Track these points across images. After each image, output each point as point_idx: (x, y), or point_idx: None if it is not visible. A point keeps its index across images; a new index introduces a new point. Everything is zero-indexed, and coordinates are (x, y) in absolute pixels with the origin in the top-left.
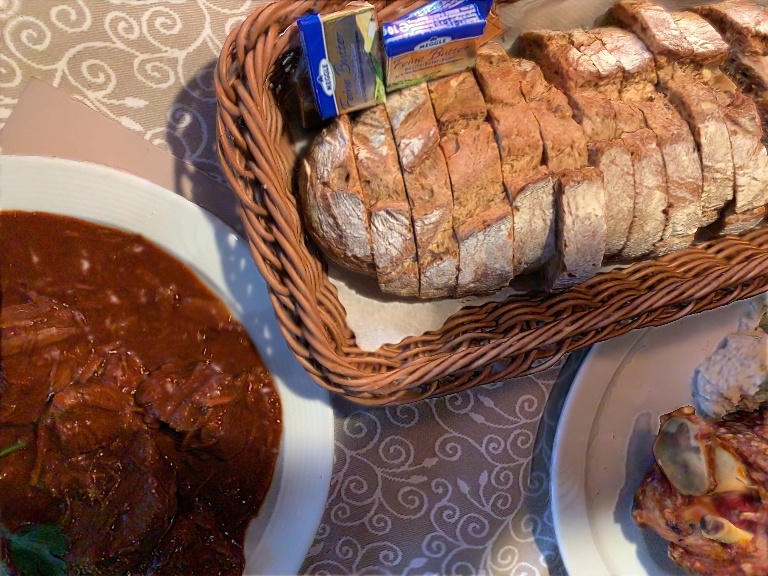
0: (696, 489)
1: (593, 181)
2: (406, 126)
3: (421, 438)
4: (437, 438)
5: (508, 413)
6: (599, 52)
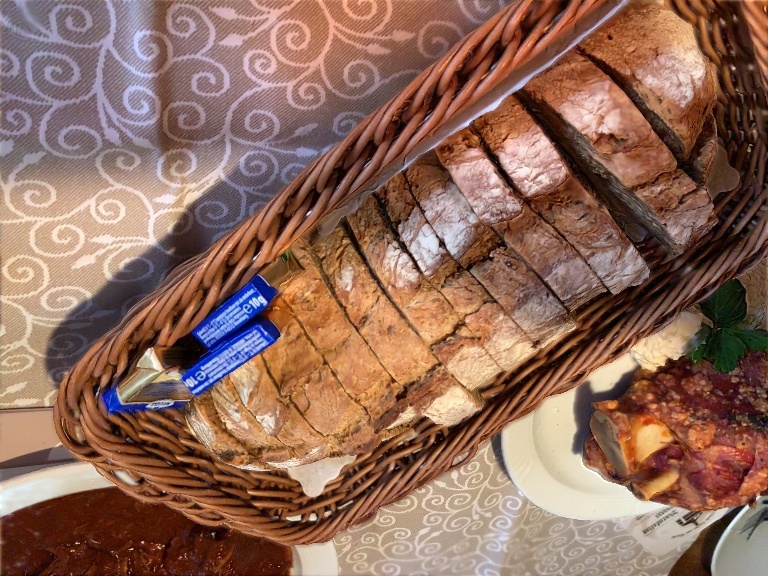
0: (622, 471)
1: (444, 393)
2: (253, 402)
3: None
4: None
5: None
6: (419, 233)
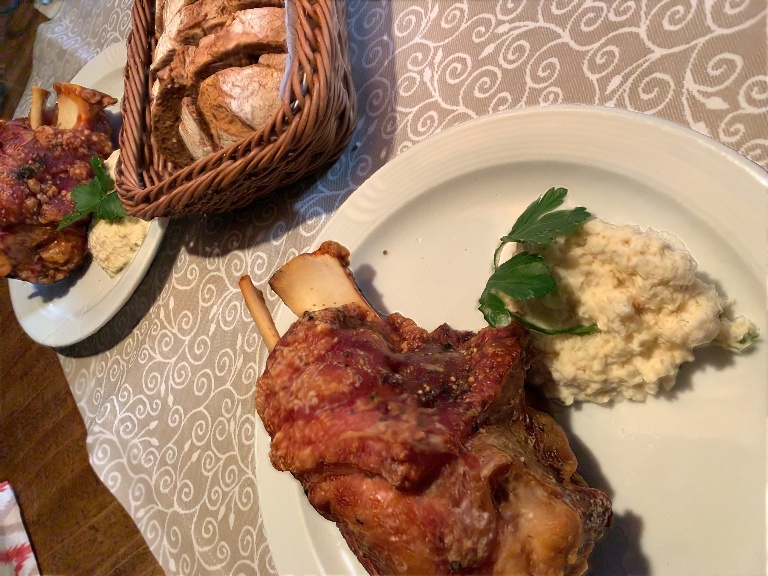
0: None
1: None
2: None
3: None
4: None
5: None
6: None
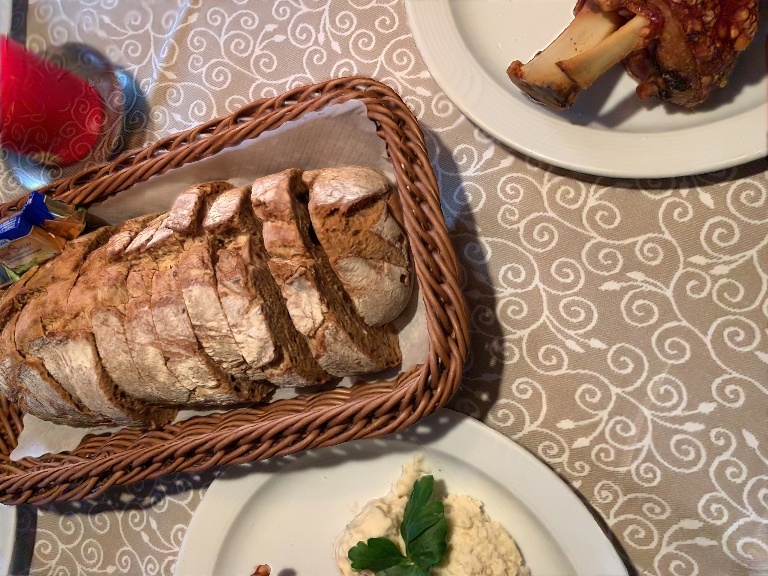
0: None
1: (76, 339)
2: (6, 298)
3: (109, 546)
4: (119, 549)
5: (165, 538)
6: None
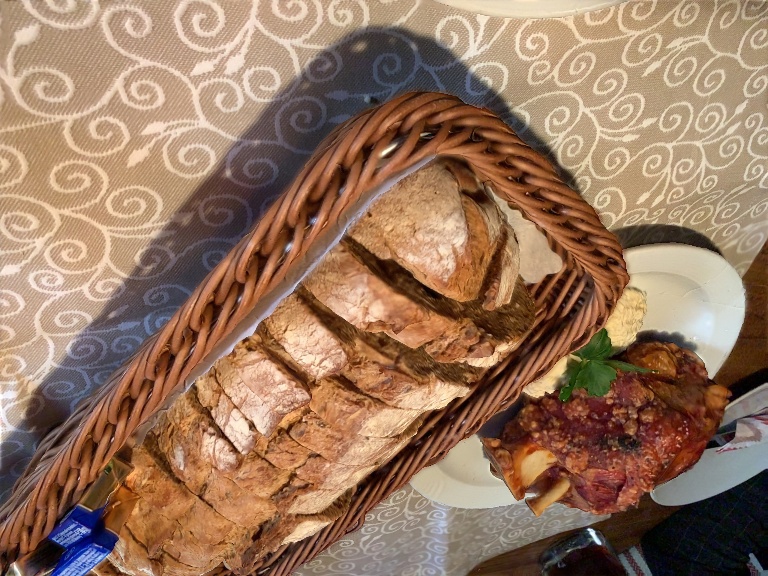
0: None
1: None
2: None
3: None
4: None
5: None
6: (229, 418)
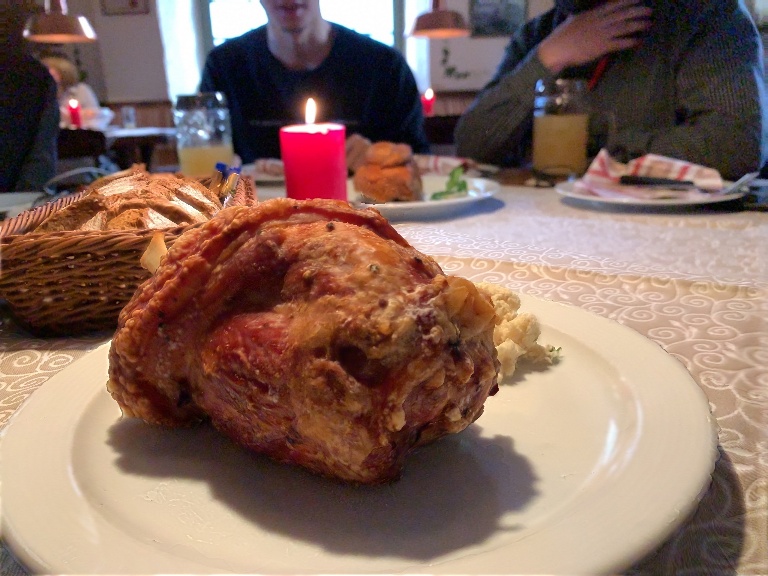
0: None
1: (132, 169)
2: None
3: None
4: None
5: None
6: None
